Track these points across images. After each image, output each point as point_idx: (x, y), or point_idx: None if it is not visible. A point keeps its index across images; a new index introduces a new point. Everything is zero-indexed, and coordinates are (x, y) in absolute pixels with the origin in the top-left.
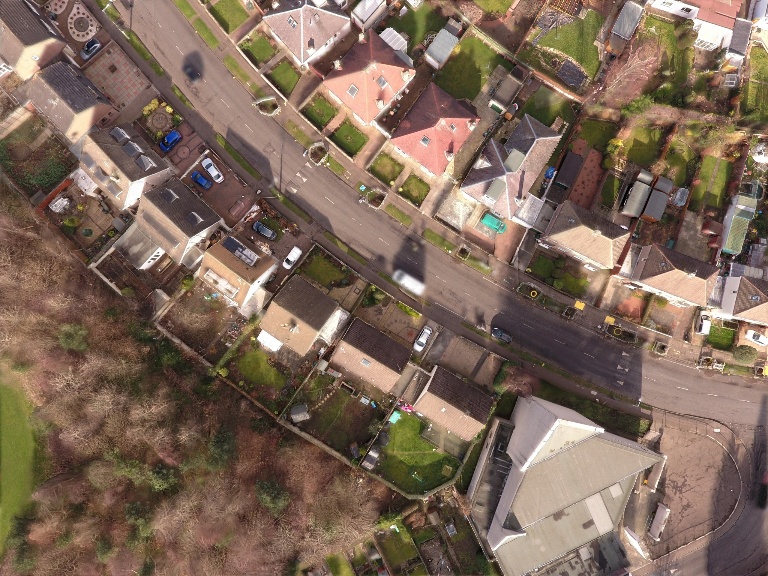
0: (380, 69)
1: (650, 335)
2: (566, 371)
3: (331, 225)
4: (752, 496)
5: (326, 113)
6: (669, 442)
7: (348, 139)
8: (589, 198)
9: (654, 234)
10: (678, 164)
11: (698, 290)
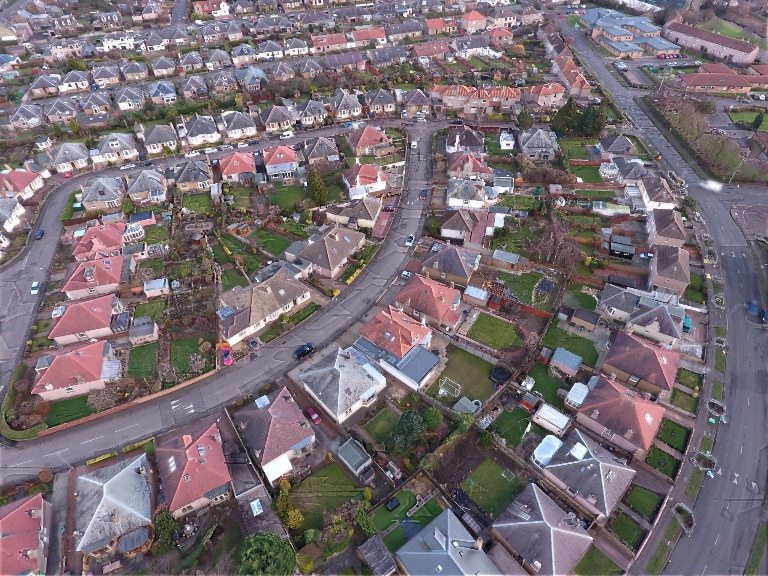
0: (623, 393)
1: (701, 243)
2: (759, 281)
3: (764, 447)
4: (761, 201)
5: (660, 457)
6: (761, 233)
7: (674, 435)
8: (629, 274)
9: (634, 243)
10: (583, 235)
11: (677, 214)
